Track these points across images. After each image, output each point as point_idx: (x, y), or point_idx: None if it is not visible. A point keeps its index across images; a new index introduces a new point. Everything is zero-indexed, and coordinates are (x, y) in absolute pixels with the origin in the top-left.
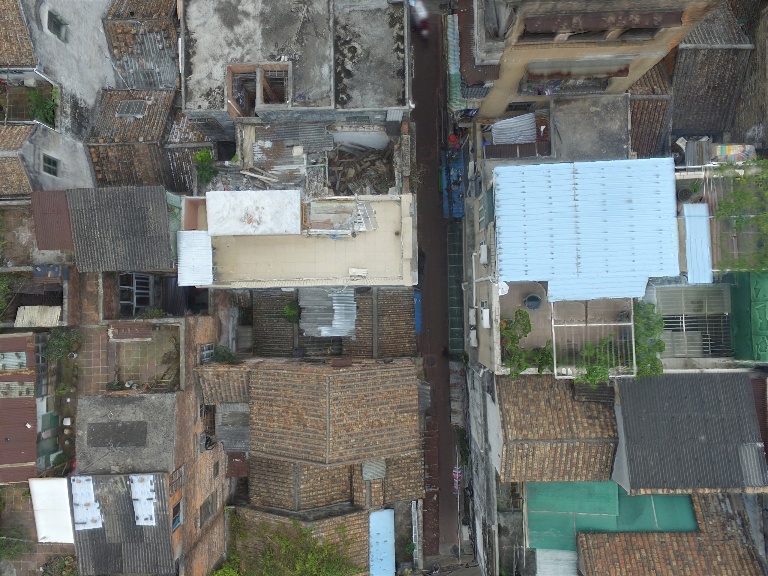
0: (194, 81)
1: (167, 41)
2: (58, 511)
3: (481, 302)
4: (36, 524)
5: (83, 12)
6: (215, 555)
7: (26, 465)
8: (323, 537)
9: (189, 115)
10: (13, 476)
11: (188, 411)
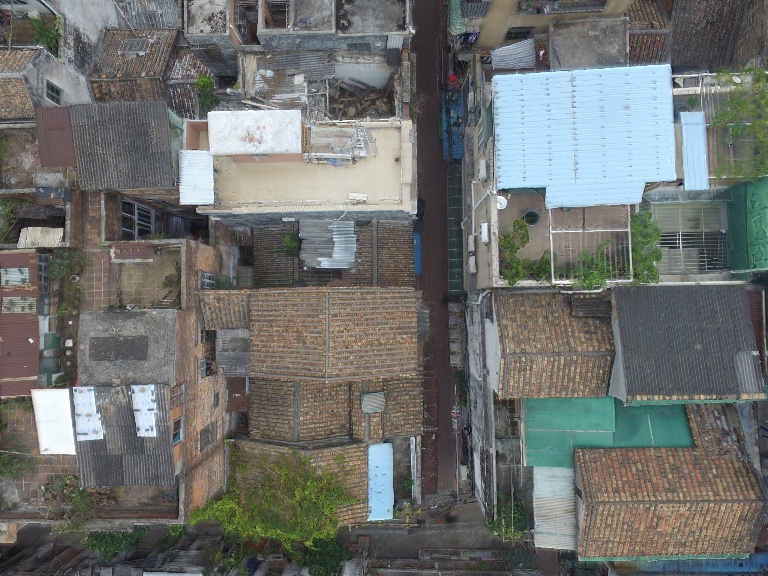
0: (196, 6)
1: None
2: (60, 423)
3: None
4: (38, 436)
5: None
6: (215, 484)
7: (28, 379)
8: (322, 466)
9: (191, 40)
10: (15, 390)
11: (189, 332)
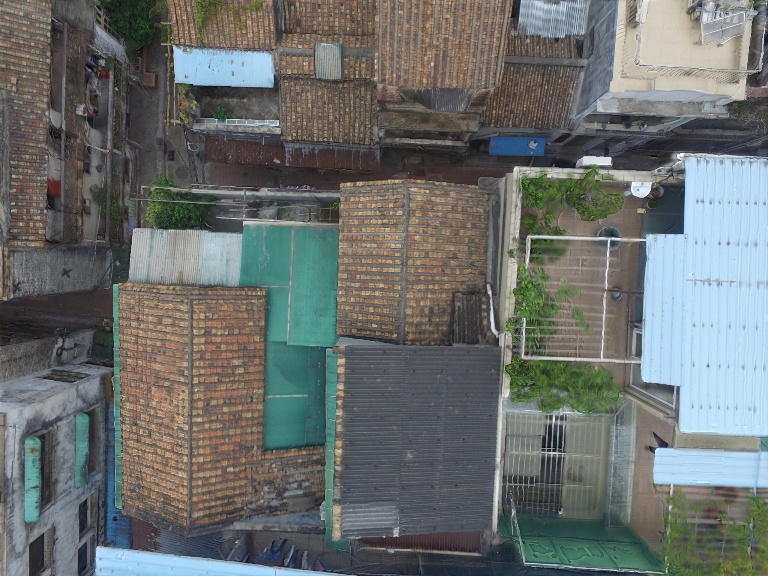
0: None
1: None
2: None
3: None
4: None
5: None
6: None
7: None
8: None
9: None
10: None
11: None
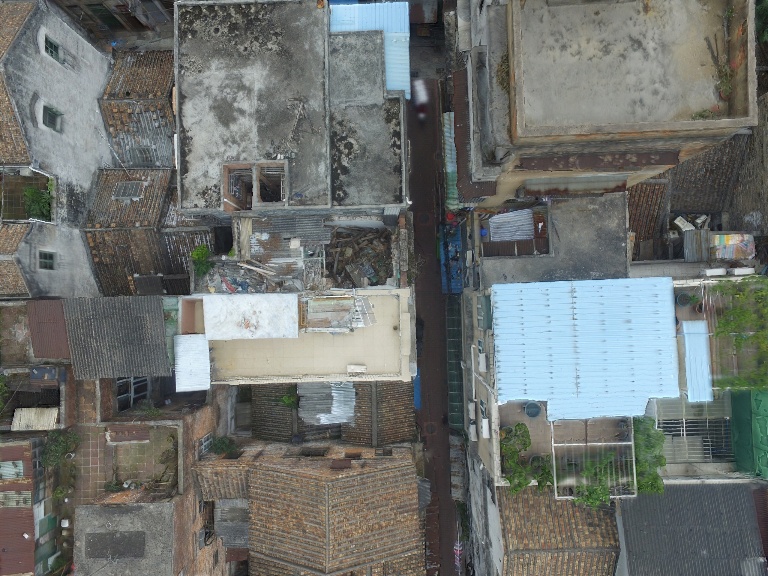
0: (190, 179)
1: (163, 119)
2: None
3: (480, 399)
4: None
5: (78, 97)
6: None
7: (24, 575)
8: None
9: (185, 213)
10: None
11: (187, 513)
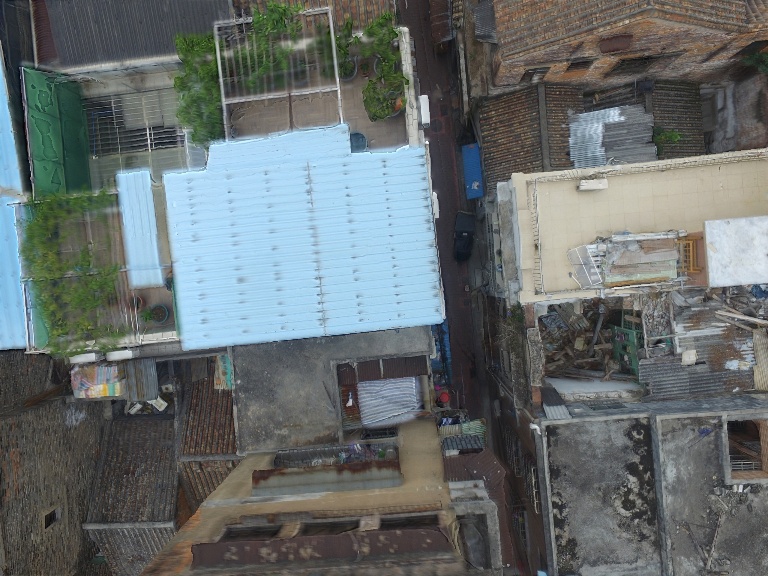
0: None
1: None
2: None
3: None
4: None
5: None
6: None
7: None
8: None
9: None
10: None
11: None
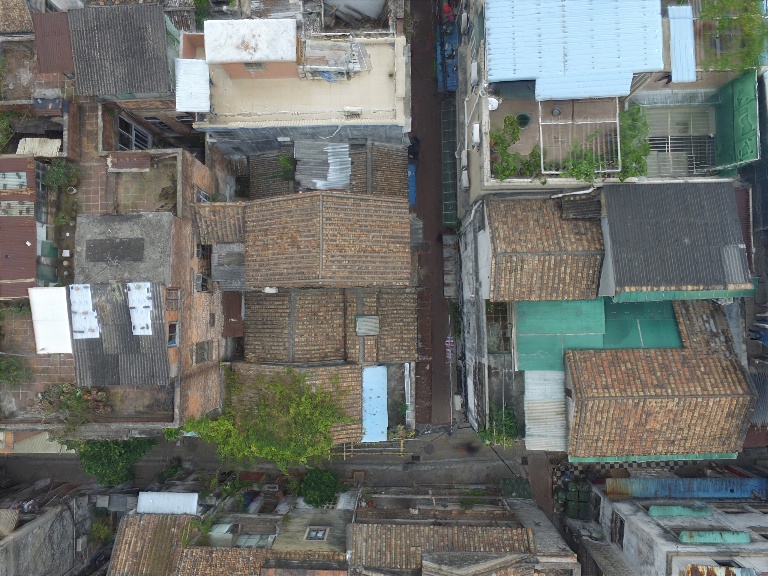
0: None
1: None
2: (57, 322)
3: None
4: (35, 335)
5: None
6: (210, 402)
7: (26, 281)
8: (317, 385)
9: None
10: (13, 291)
11: (185, 241)
